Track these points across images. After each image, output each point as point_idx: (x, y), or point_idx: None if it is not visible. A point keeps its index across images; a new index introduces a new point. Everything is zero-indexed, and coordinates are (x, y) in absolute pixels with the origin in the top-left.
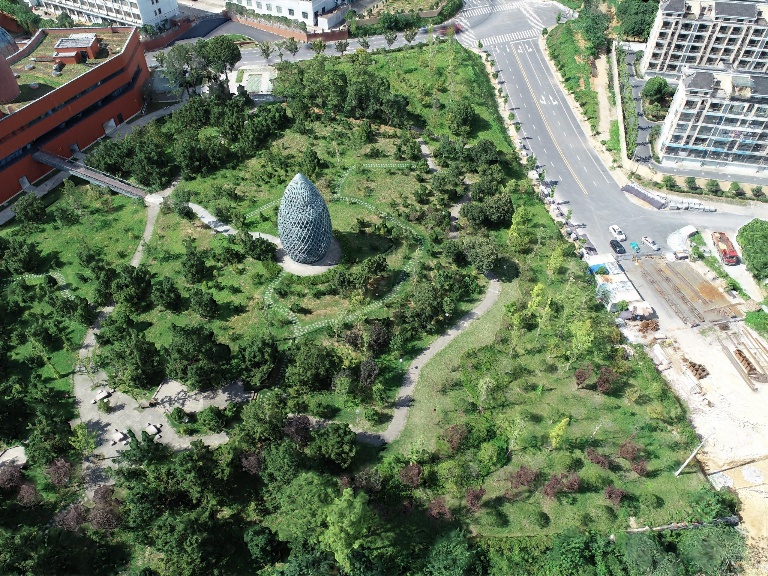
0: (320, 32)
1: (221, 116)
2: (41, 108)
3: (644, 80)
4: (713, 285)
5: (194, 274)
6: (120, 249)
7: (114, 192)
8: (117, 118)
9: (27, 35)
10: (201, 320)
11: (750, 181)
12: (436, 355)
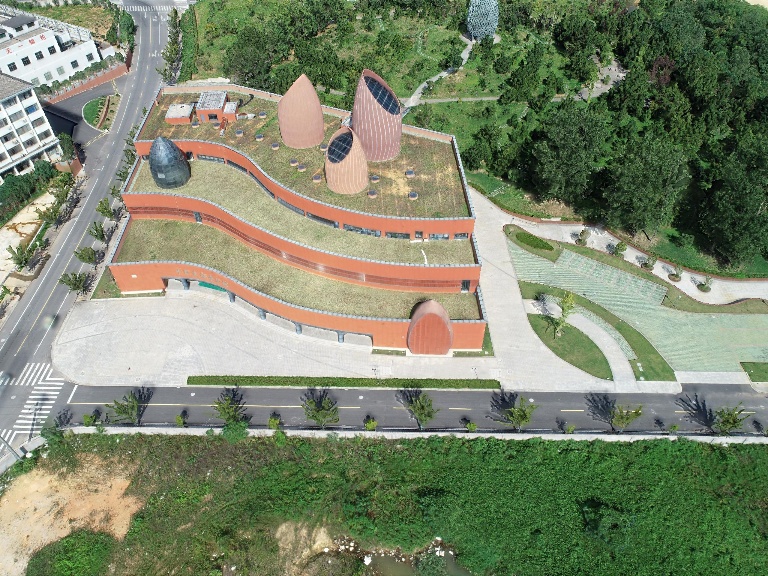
0: None
1: None
2: None
3: None
4: None
5: None
6: None
7: None
8: None
9: None
10: None
11: None
12: None
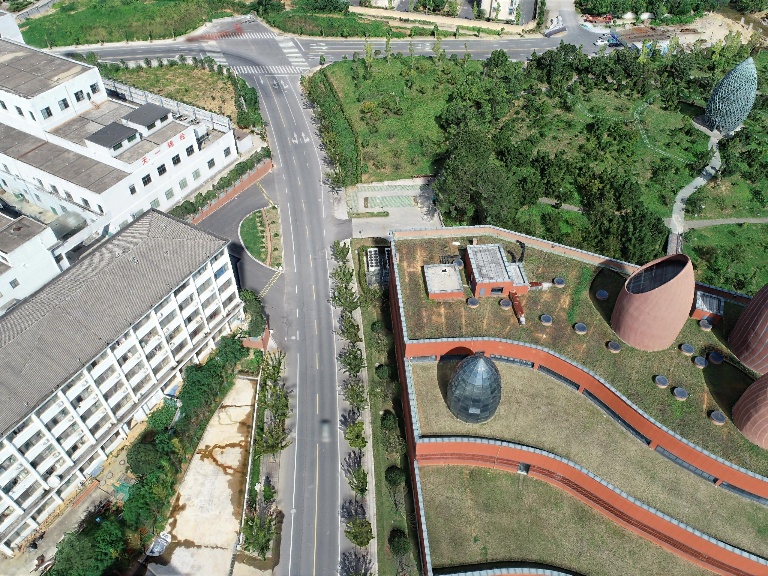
0: None
1: None
2: None
3: (396, 8)
4: (633, 28)
5: None
6: (761, 233)
7: None
8: None
9: None
10: None
11: (526, 3)
12: (764, 93)
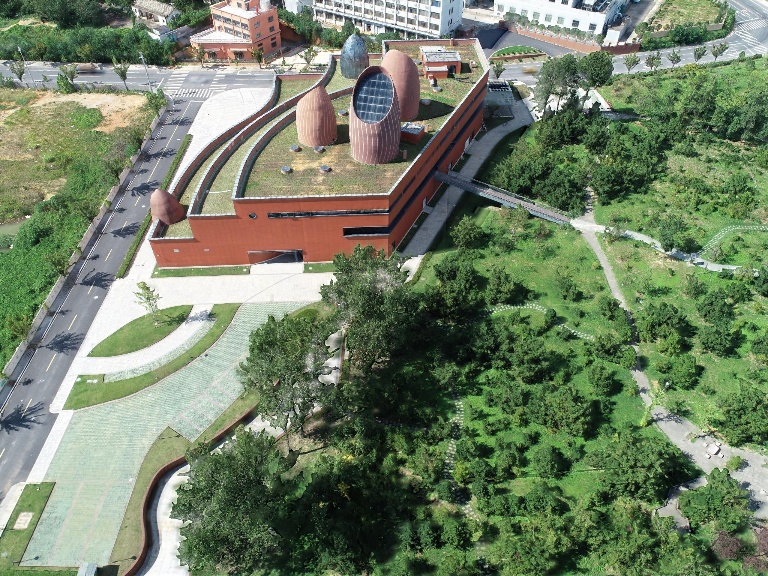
0: (612, 45)
1: (600, 136)
2: (448, 126)
3: None
4: None
5: (723, 313)
6: (590, 280)
7: (530, 216)
8: (471, 134)
9: (305, 44)
10: (759, 365)
11: None
12: None
